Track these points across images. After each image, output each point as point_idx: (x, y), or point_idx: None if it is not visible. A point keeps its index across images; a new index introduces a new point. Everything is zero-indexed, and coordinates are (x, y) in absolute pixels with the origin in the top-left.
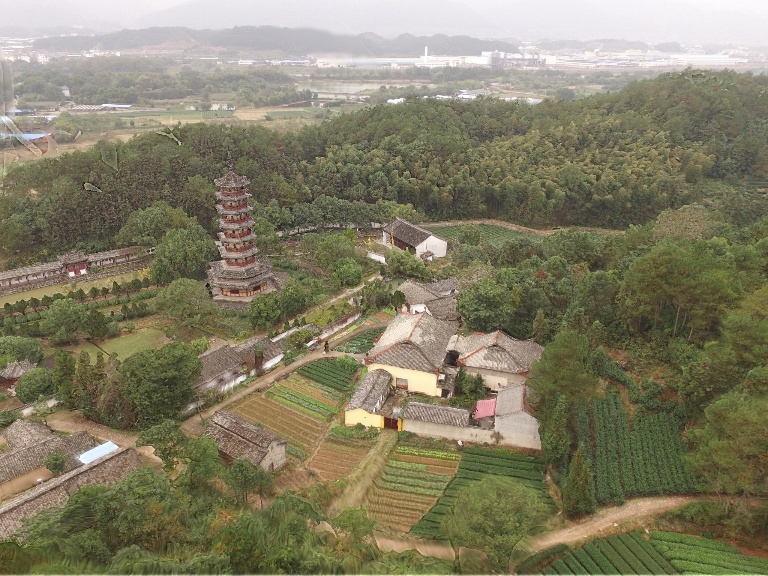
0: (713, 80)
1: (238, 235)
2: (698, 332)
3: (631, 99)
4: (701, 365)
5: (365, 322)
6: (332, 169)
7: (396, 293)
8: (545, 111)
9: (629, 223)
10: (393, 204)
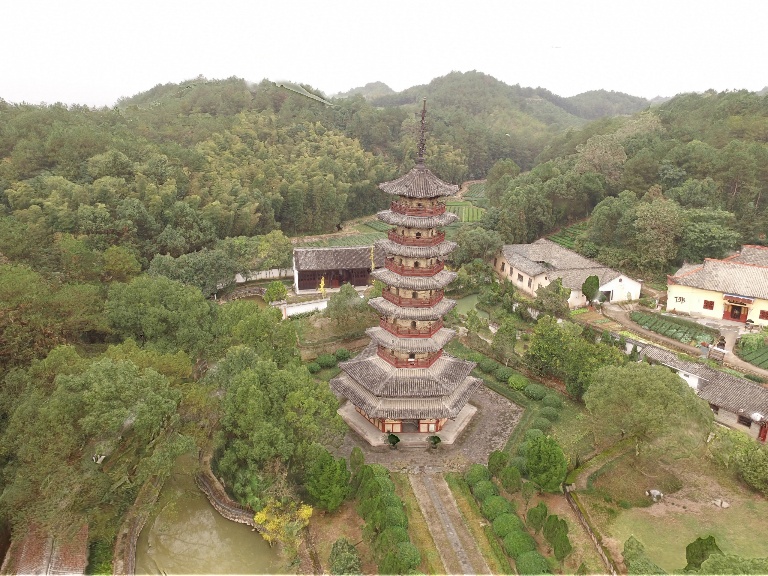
0: (266, 81)
1: (442, 294)
2: (760, 198)
3: (224, 101)
4: None
5: (612, 326)
6: (105, 215)
7: (593, 280)
8: (156, 119)
9: (375, 206)
10: (247, 240)
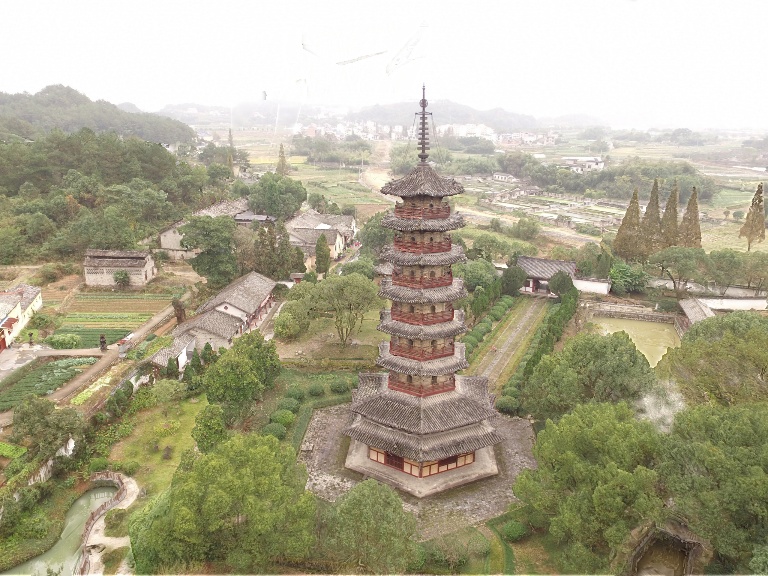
0: None
1: None
2: None
3: None
4: None
5: None
6: None
7: None
8: None
9: None
10: None
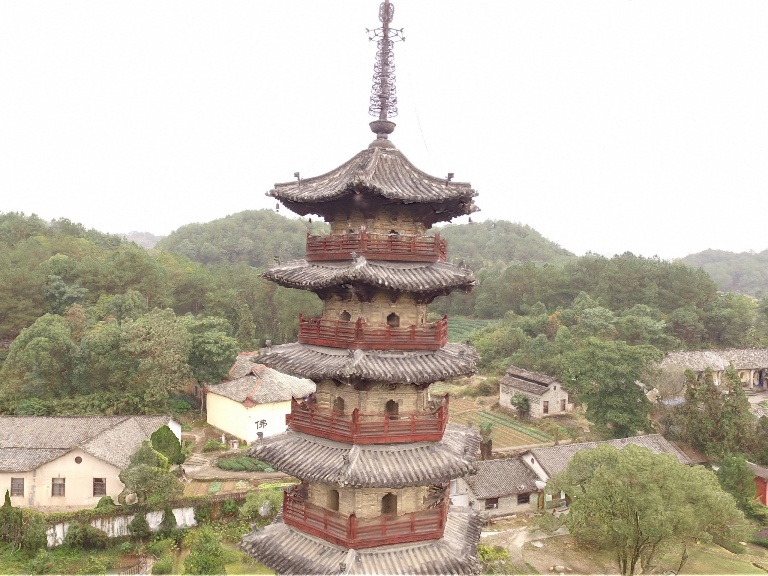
0: None
1: None
2: None
3: None
4: None
5: (240, 486)
6: None
7: (169, 432)
8: None
9: None
10: None
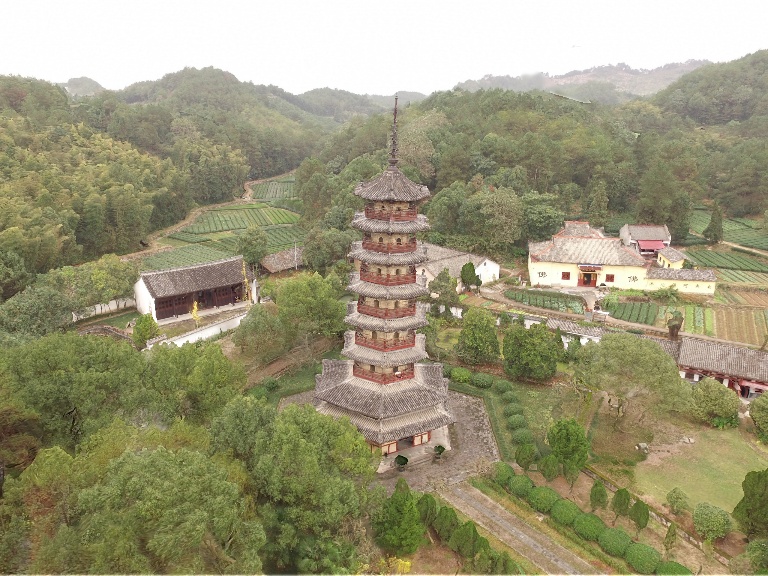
0: None
1: None
2: None
3: None
4: (621, 172)
5: (499, 307)
6: None
7: (470, 267)
8: None
9: (173, 216)
10: (74, 270)
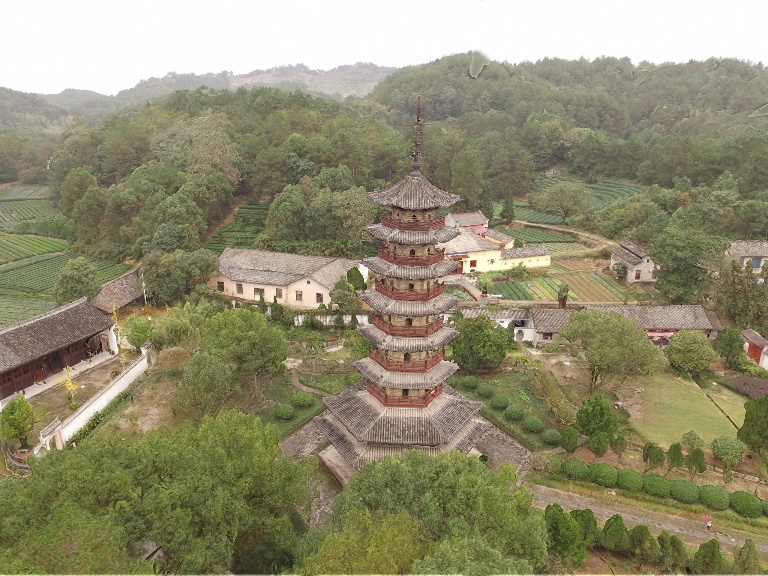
0: None
1: None
2: None
3: None
4: None
5: None
6: None
7: (357, 271)
8: None
9: None
10: None
